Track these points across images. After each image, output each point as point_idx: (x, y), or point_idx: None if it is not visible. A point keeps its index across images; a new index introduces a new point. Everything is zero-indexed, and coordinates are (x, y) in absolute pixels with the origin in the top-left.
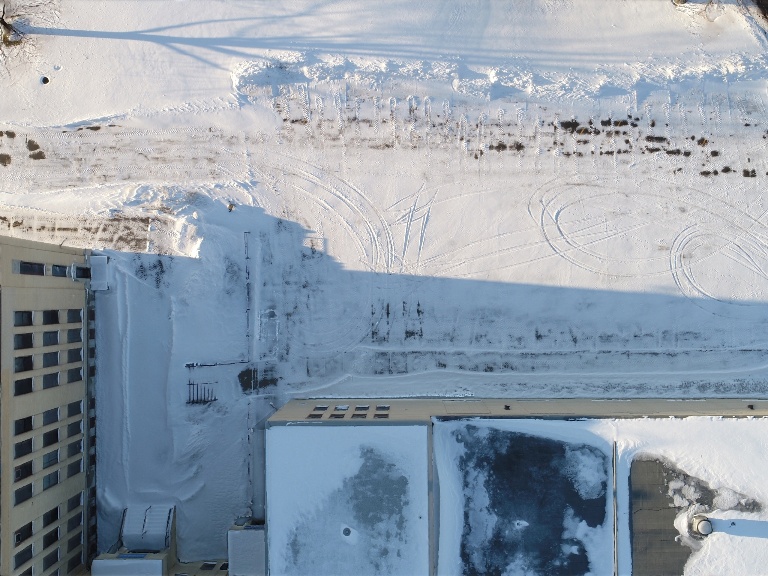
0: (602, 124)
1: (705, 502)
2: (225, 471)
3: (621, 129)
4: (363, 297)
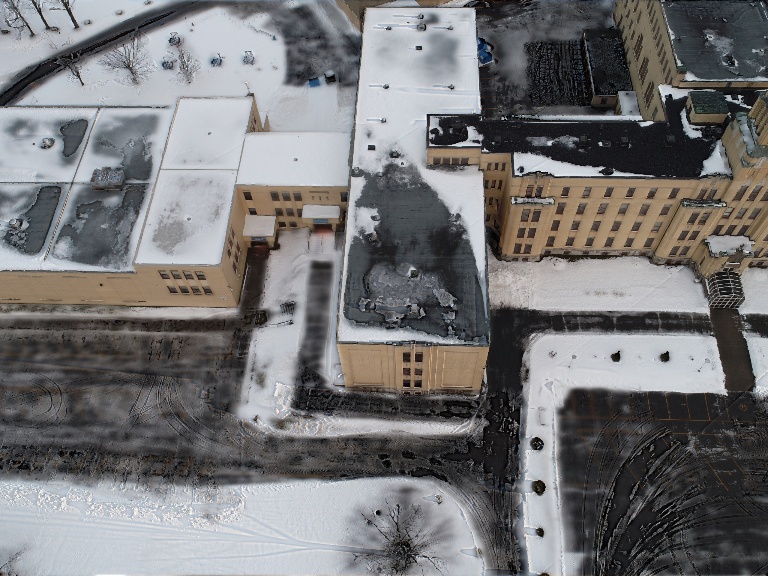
0: (3, 467)
1: (10, 234)
2: (282, 271)
3: None
4: (183, 363)
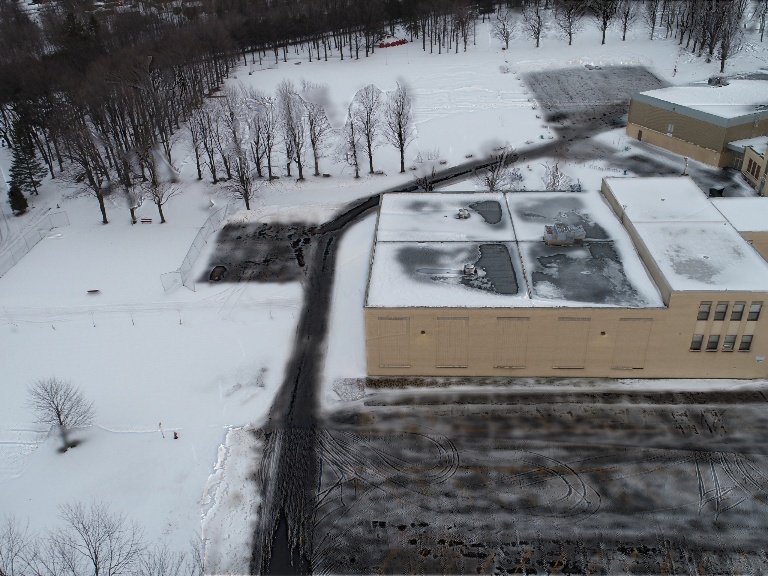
0: (536, 571)
1: (467, 280)
2: None
3: (515, 565)
4: (738, 437)
